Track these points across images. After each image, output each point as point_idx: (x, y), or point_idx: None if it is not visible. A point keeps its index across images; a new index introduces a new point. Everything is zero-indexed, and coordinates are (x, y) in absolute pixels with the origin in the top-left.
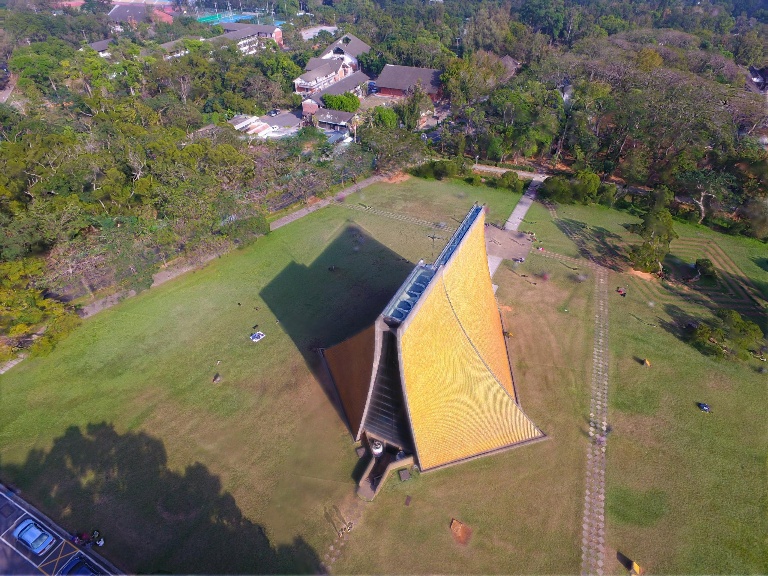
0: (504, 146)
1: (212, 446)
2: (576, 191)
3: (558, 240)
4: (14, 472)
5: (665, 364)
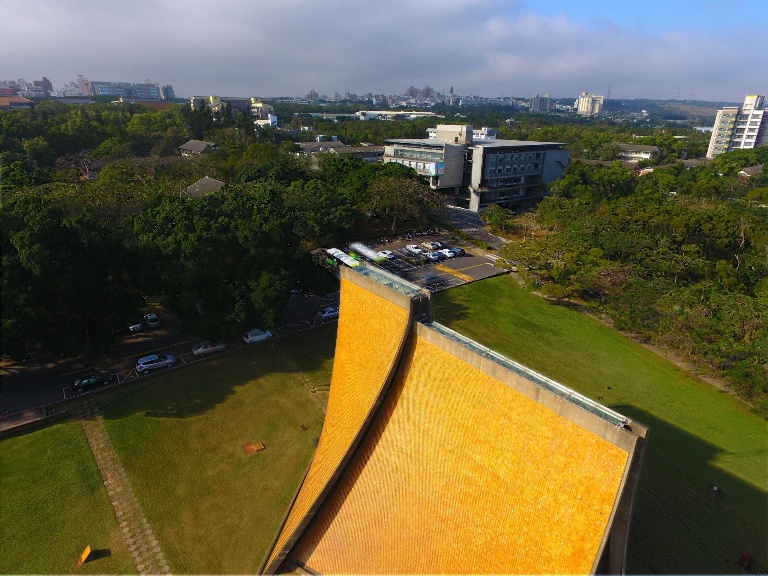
0: None
1: None
2: None
3: None
4: (444, 294)
5: None
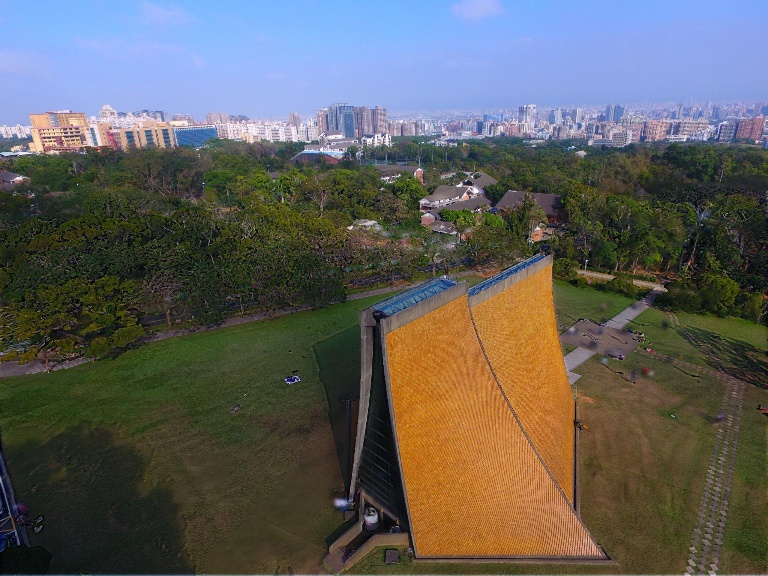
0: (619, 252)
1: (196, 468)
2: (705, 297)
3: (675, 345)
4: (17, 445)
5: None
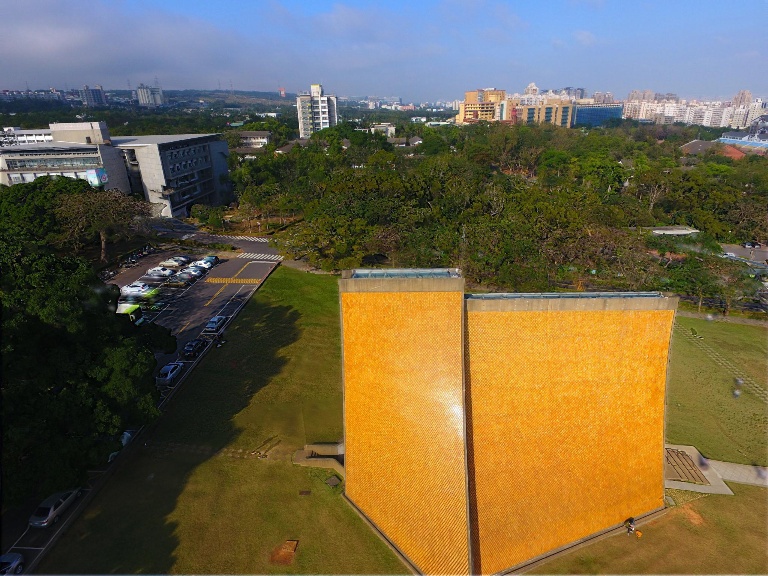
0: None
1: (307, 360)
2: None
3: None
4: (254, 303)
5: None
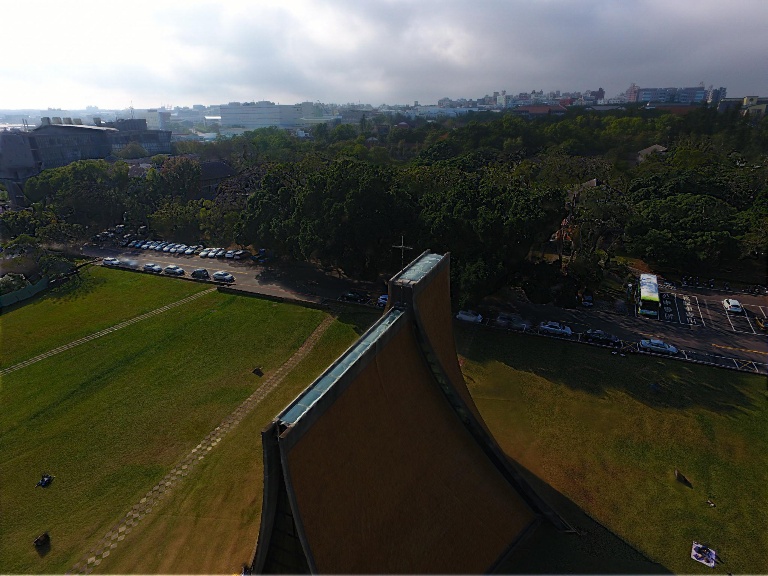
0: None
1: (605, 412)
2: None
3: None
4: (741, 376)
5: (6, 547)
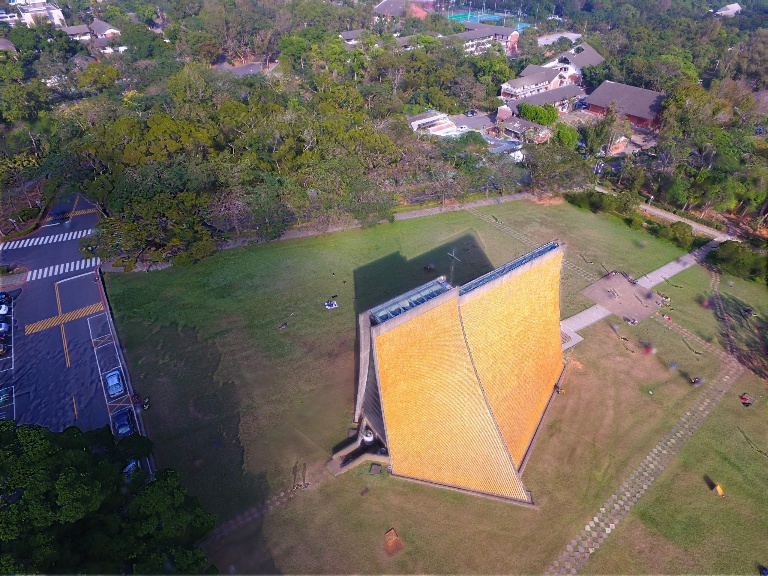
0: (691, 192)
1: (250, 375)
2: (756, 265)
3: (698, 315)
4: (129, 337)
5: (747, 503)
